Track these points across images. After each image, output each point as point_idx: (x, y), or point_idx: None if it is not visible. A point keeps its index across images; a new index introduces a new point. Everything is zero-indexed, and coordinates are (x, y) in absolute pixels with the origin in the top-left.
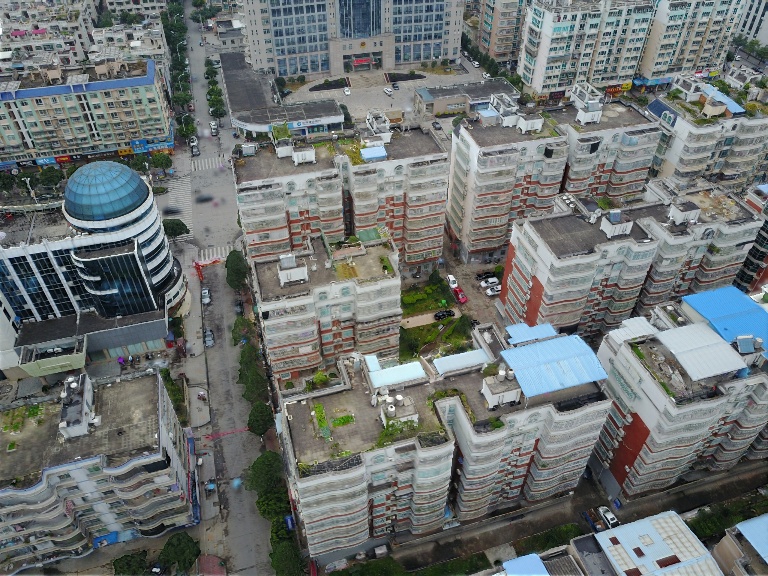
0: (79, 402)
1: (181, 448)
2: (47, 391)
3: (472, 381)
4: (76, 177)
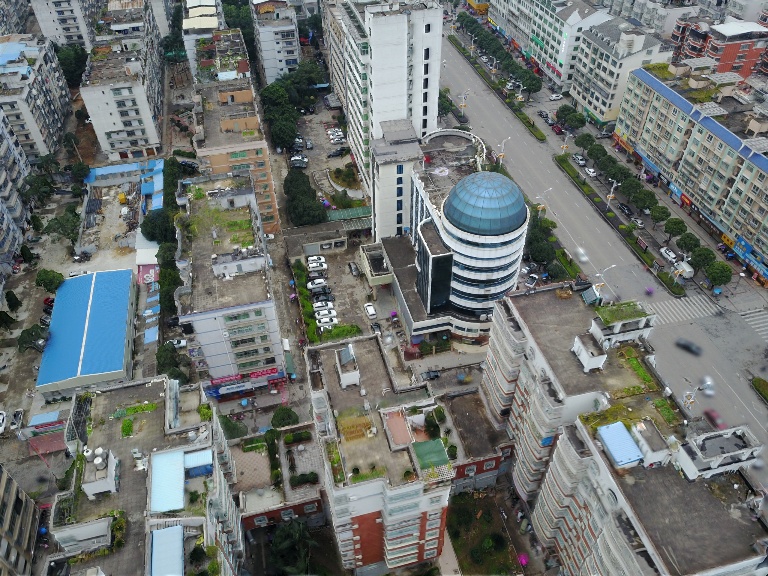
0: (235, 260)
1: (247, 358)
2: (362, 278)
3: (130, 569)
4: (475, 173)
